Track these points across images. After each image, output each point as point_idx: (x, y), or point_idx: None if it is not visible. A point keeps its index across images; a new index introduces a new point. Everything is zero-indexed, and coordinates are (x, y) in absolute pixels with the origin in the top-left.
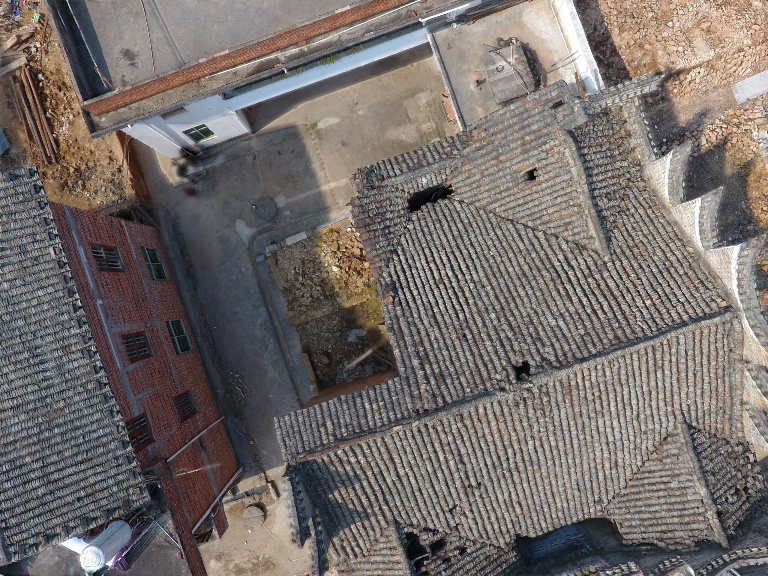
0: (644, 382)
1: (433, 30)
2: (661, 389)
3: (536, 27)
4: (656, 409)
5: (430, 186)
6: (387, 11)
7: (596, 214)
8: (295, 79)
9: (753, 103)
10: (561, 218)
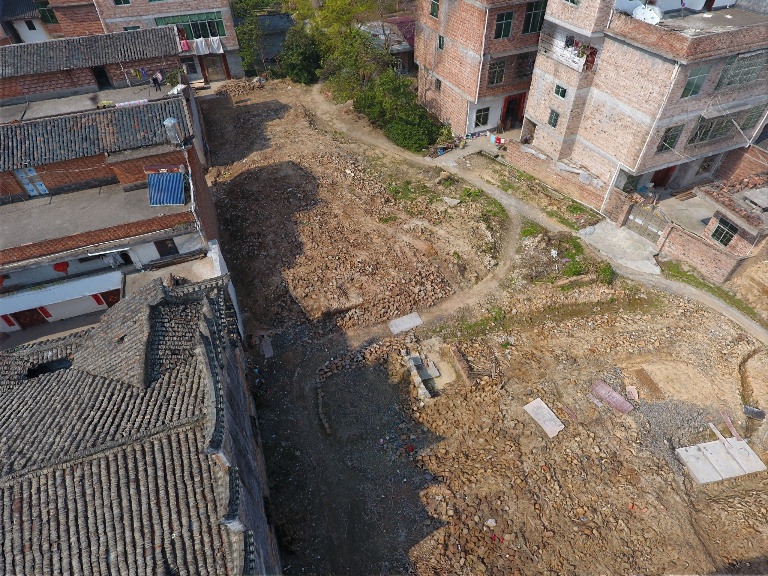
0: (113, 499)
1: (127, 274)
2: (135, 512)
3: (200, 272)
4: (131, 544)
5: (54, 359)
6: (69, 250)
7: (144, 356)
8: (10, 301)
9: (406, 334)
10: None
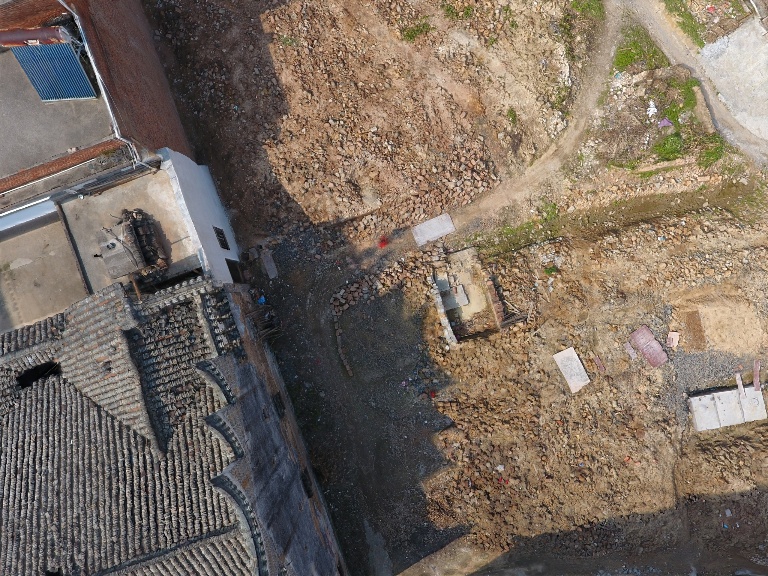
0: None
1: (61, 201)
2: None
3: (160, 199)
4: None
5: (38, 364)
6: None
7: (147, 415)
8: None
9: (433, 245)
10: (132, 411)
